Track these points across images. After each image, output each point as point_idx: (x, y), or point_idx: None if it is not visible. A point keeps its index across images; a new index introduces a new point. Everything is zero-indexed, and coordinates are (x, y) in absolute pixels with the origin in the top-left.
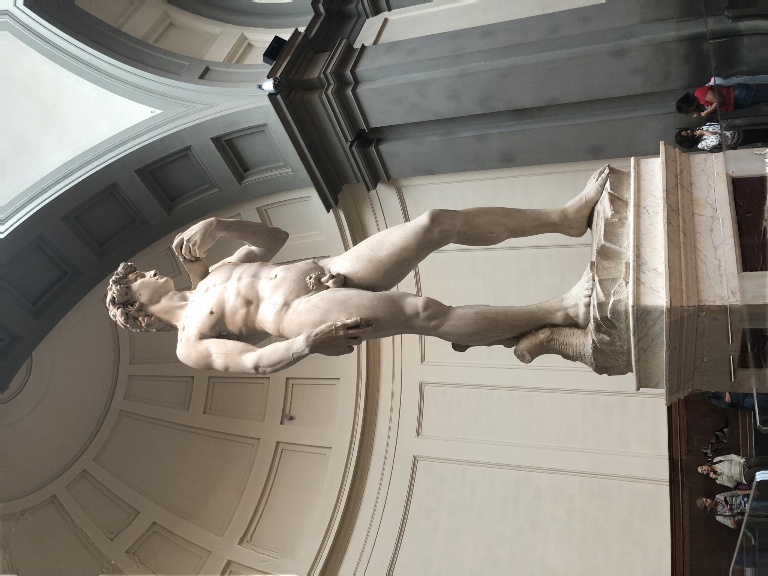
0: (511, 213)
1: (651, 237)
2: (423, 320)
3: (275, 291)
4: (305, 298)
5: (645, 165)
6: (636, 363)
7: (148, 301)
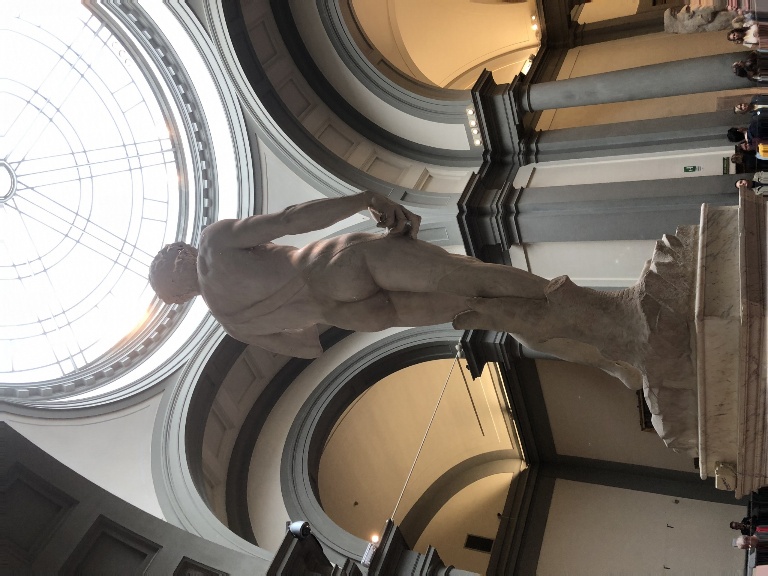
0: None
1: None
2: (465, 257)
3: None
4: None
5: None
6: (702, 271)
7: None
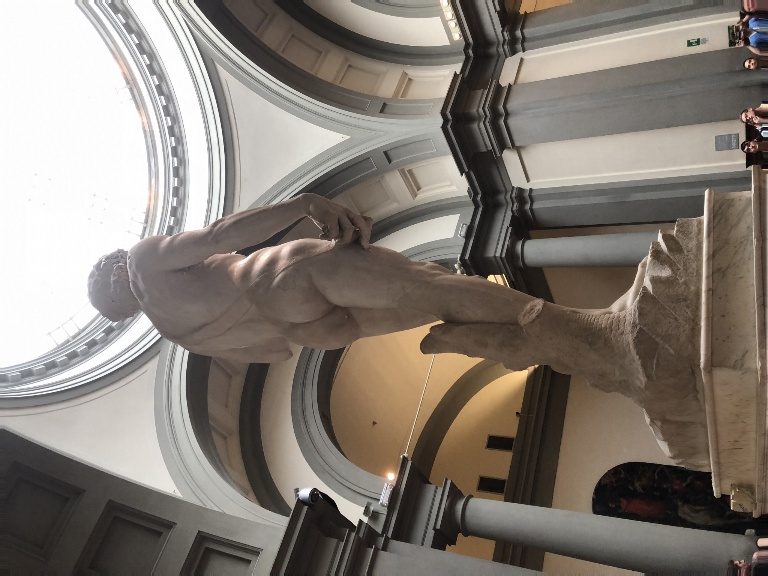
0: None
1: None
2: (426, 268)
3: None
4: None
5: None
6: (708, 297)
7: None
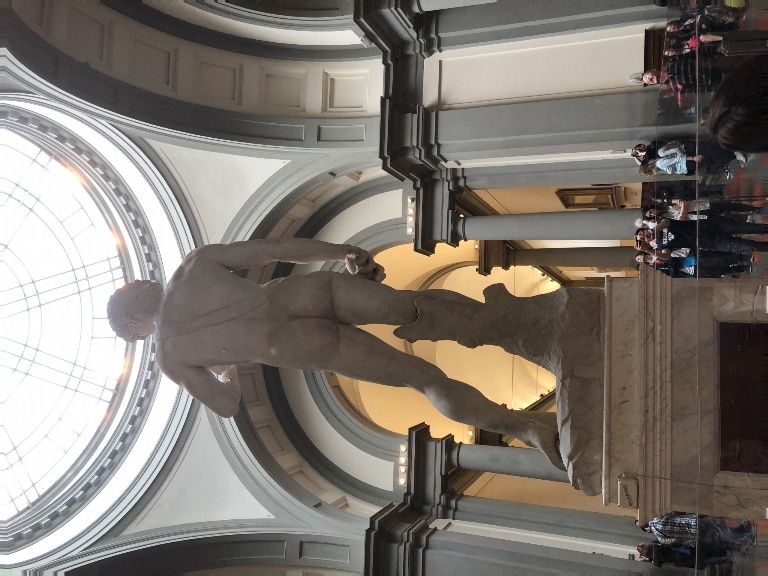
0: None
1: None
2: None
3: None
4: None
5: None
6: None
7: None
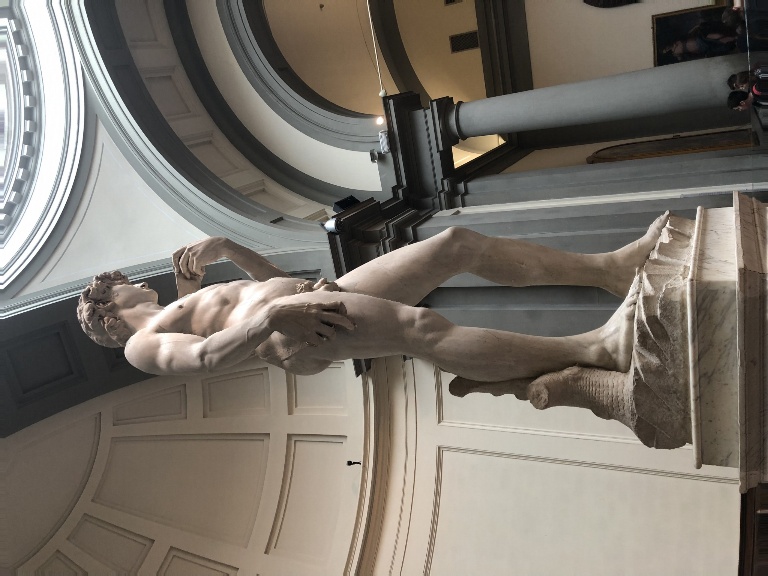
0: (548, 250)
1: (719, 244)
2: (418, 330)
3: (258, 290)
4: (288, 296)
5: (714, 210)
6: (696, 404)
7: (122, 303)
